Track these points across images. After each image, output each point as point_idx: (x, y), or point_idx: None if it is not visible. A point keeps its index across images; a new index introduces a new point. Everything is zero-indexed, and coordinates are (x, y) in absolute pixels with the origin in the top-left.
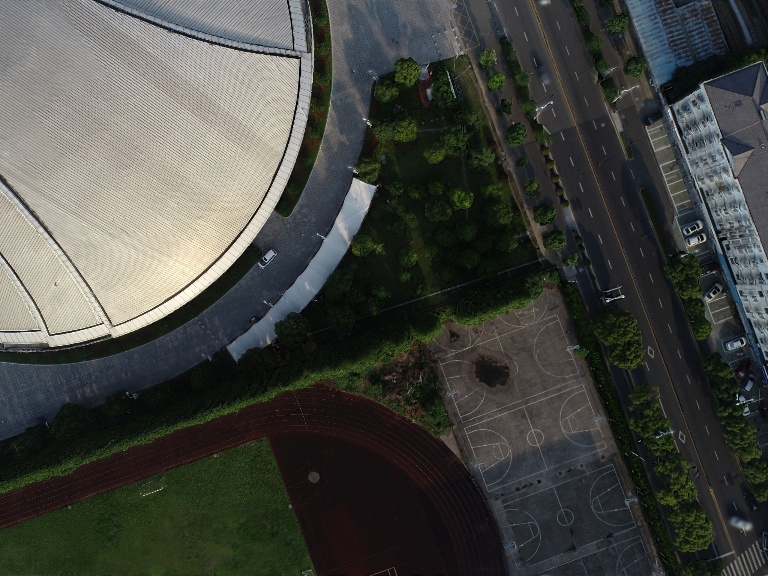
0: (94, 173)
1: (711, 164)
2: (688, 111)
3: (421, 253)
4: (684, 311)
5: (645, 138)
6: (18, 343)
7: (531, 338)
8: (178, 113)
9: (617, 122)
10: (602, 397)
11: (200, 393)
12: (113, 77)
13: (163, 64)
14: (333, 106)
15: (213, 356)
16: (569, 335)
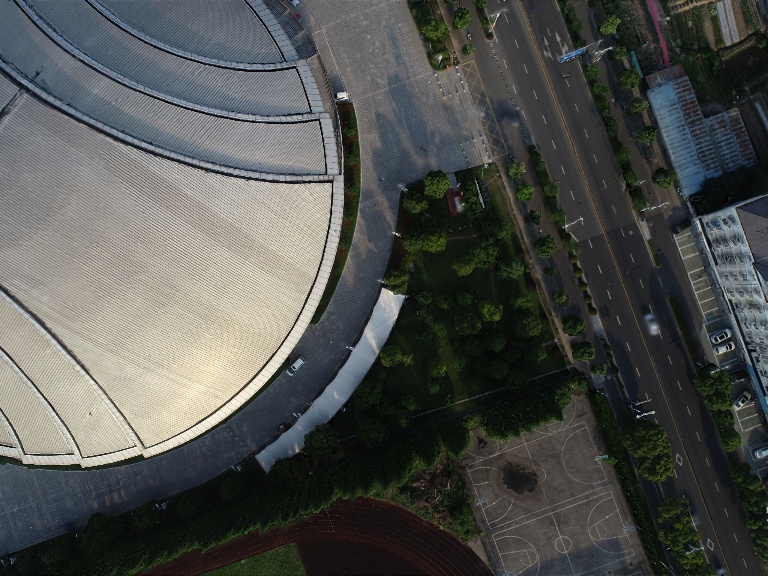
0: (131, 313)
1: (742, 282)
2: (718, 227)
3: (450, 362)
4: (712, 419)
5: (673, 246)
6: (51, 464)
7: (559, 445)
8: (214, 250)
9: (645, 230)
10: (630, 506)
11: (229, 503)
12: (151, 221)
13: (200, 204)
14: (361, 214)
15: (241, 464)
16: (597, 442)
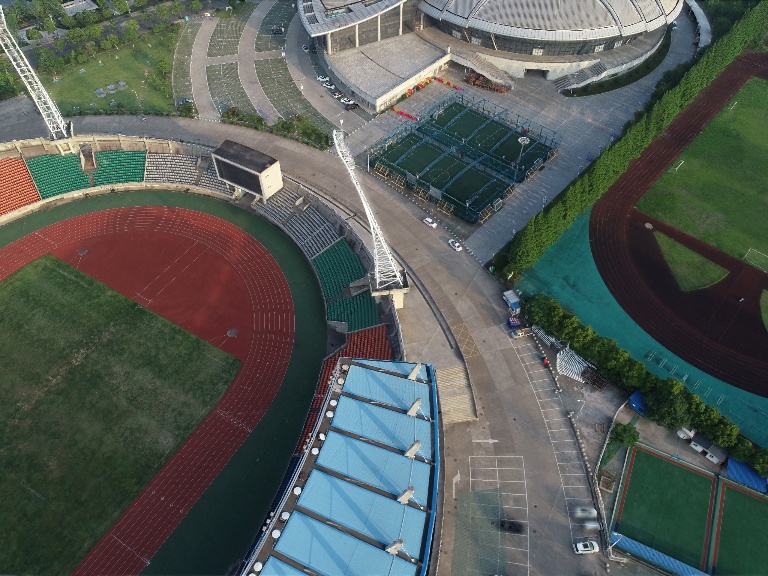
0: None
1: None
2: None
3: None
4: None
5: None
6: (634, 33)
7: None
8: None
9: None
10: None
11: None
12: None
13: None
14: None
15: None
16: None
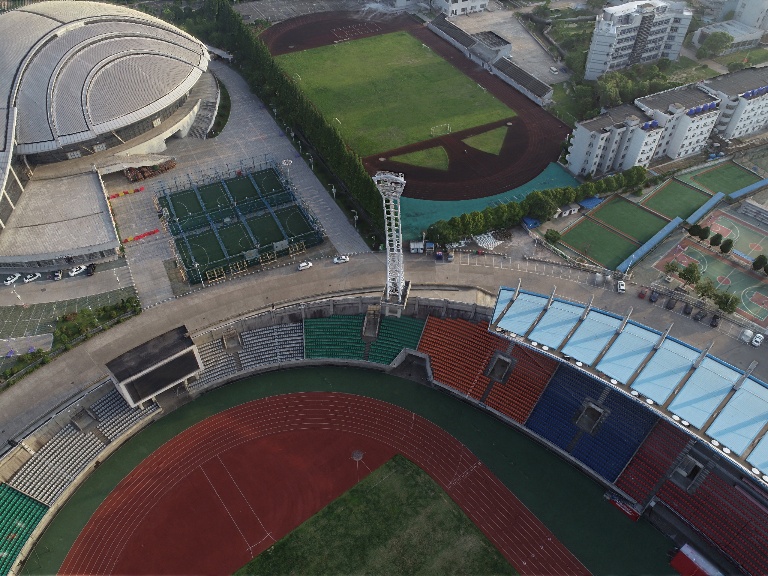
0: None
1: None
2: None
3: None
4: None
5: None
6: None
7: None
8: None
9: (145, 2)
10: None
11: None
12: None
13: None
14: None
15: None
16: (231, 6)
